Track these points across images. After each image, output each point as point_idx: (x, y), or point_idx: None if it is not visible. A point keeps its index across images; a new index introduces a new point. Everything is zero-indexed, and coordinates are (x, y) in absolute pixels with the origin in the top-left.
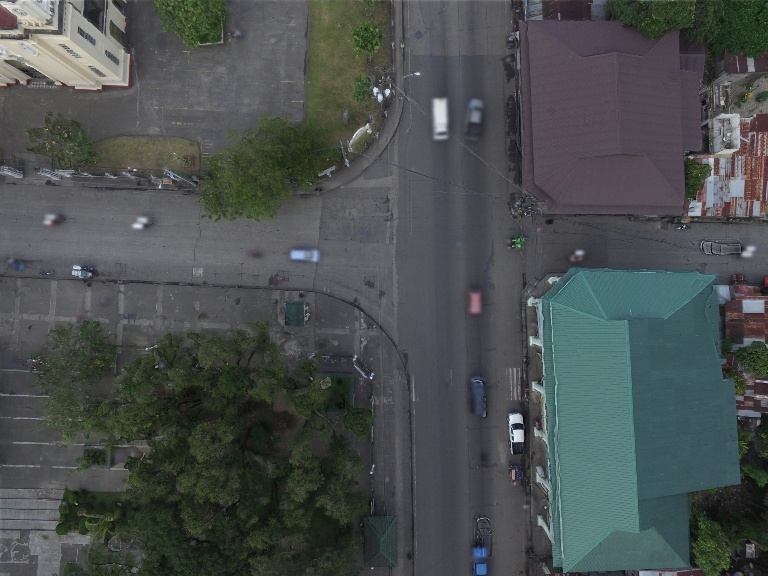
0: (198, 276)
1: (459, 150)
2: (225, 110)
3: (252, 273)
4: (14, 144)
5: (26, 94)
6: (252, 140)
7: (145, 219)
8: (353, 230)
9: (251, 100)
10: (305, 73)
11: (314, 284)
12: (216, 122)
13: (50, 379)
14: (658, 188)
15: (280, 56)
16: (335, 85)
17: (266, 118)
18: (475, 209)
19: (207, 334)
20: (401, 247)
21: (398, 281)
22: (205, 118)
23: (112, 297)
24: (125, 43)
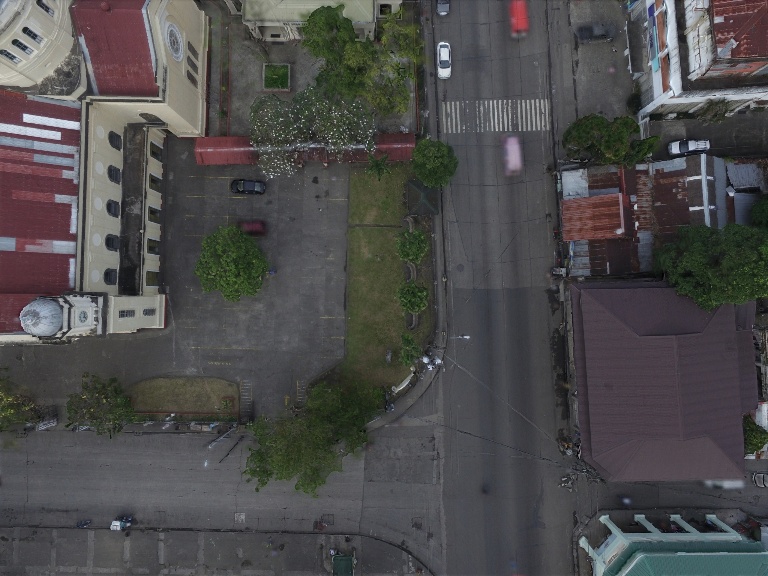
0: (240, 522)
1: (505, 386)
2: (264, 348)
3: (296, 517)
4: (46, 389)
5: None
6: (303, 430)
7: (184, 464)
8: (399, 470)
9: (290, 337)
10: (345, 308)
11: (360, 527)
12: (255, 361)
13: None
14: (719, 464)
15: (319, 291)
16: (376, 320)
17: (316, 402)
18: (523, 447)
19: None
20: (448, 487)
21: (446, 522)
22: (243, 357)
23: (152, 546)
24: (159, 282)
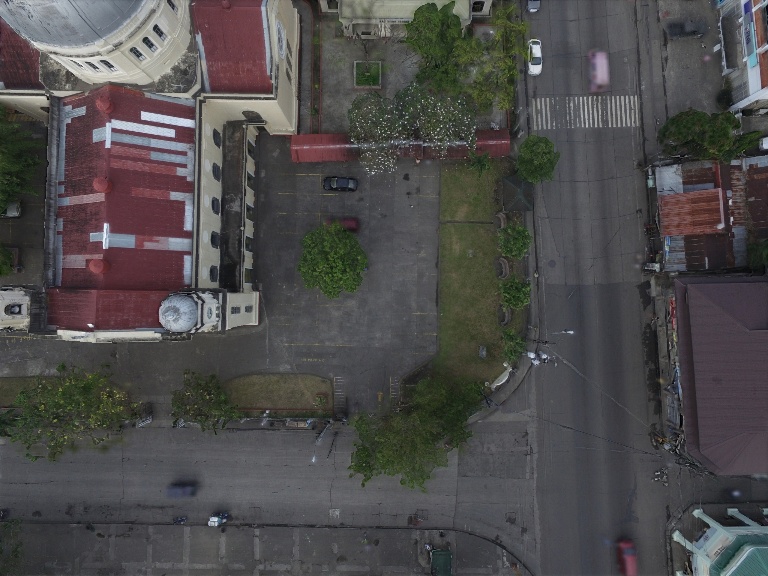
0: (335, 518)
1: (598, 381)
2: (357, 345)
3: (390, 513)
4: (141, 386)
5: None
6: (416, 425)
7: (279, 460)
8: (492, 466)
9: (383, 334)
10: (437, 304)
11: (454, 522)
12: (348, 358)
13: None
14: None
15: (411, 287)
16: (468, 316)
17: (427, 397)
18: None
19: None
20: (542, 482)
21: (540, 517)
22: (337, 354)
23: (247, 542)
24: (253, 279)
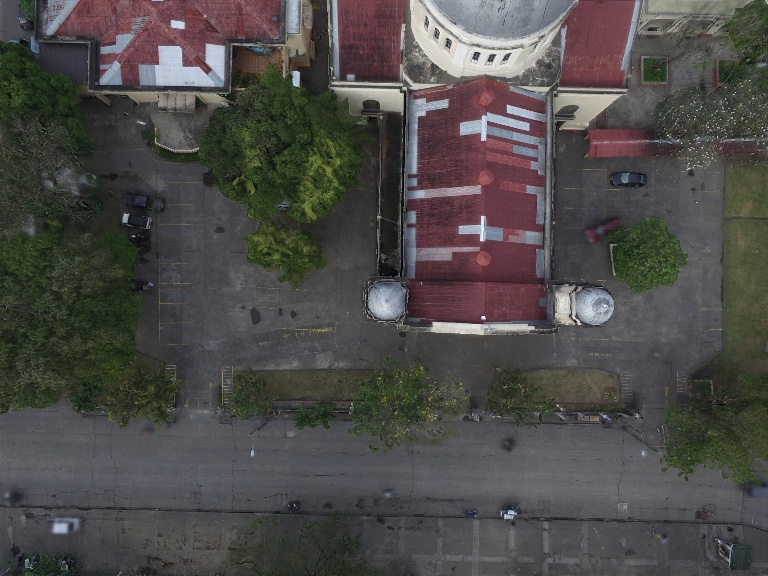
0: (623, 511)
1: None
2: (643, 340)
3: (678, 507)
4: None
5: None
6: (765, 419)
7: (567, 454)
8: None
9: (669, 329)
10: (723, 300)
11: (741, 517)
12: (635, 352)
13: None
14: None
15: (696, 283)
16: (753, 311)
17: None
18: None
19: (635, 571)
20: None
21: None
22: (623, 348)
23: (536, 535)
24: None
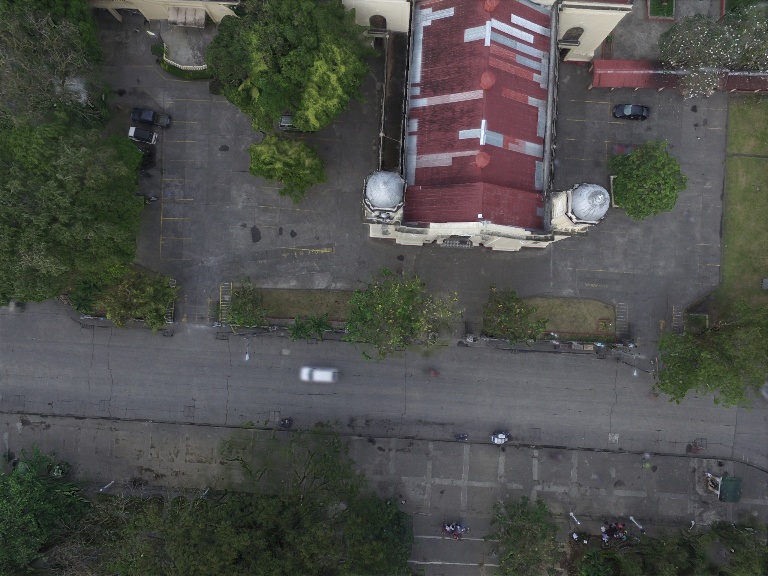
0: (614, 442)
1: None
2: (640, 273)
3: (669, 440)
4: None
5: (438, 253)
6: (758, 339)
7: (560, 383)
8: None
9: (667, 263)
10: (721, 236)
11: (732, 453)
12: (631, 285)
13: (528, 572)
14: None
15: (696, 218)
16: (751, 249)
17: (764, 314)
18: None
19: (624, 502)
20: None
21: None
22: (620, 280)
23: (526, 462)
24: None
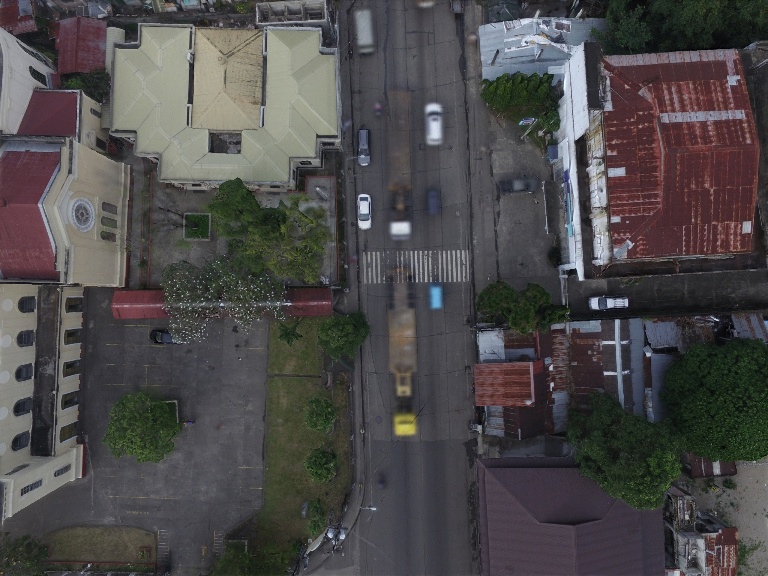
0: None
1: (421, 540)
2: (182, 498)
3: None
4: None
5: None
6: None
7: None
8: None
9: (208, 487)
10: (263, 458)
11: None
12: (173, 511)
13: None
14: None
15: (238, 441)
16: (294, 470)
17: None
18: None
19: None
20: None
21: None
22: (161, 507)
23: None
24: (78, 431)
